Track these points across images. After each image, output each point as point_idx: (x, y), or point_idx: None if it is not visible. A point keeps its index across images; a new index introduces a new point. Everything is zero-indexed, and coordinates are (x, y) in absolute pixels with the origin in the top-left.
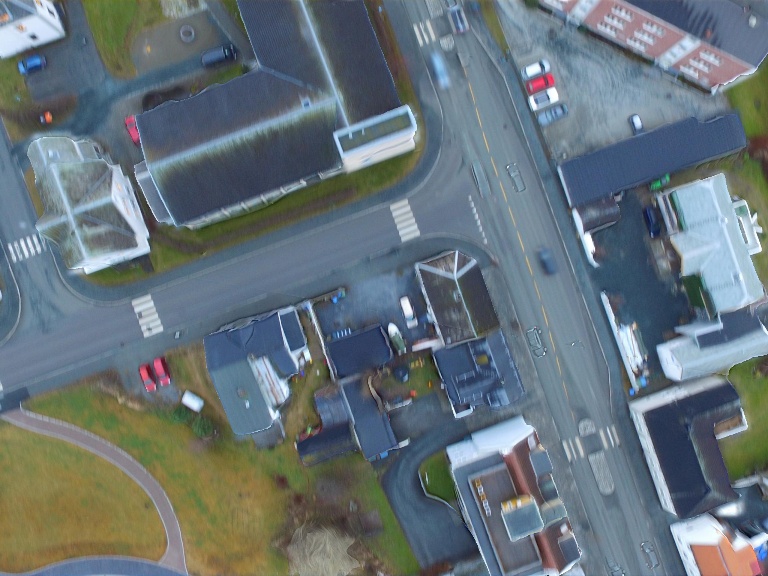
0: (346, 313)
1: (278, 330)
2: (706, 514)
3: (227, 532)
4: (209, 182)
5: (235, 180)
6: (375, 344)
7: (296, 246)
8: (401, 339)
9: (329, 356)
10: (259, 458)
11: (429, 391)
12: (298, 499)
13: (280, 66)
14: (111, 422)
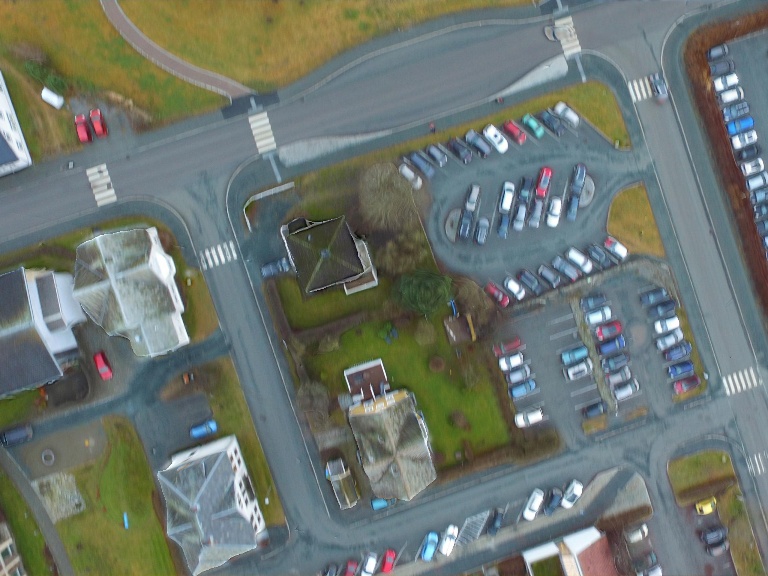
0: None
1: None
2: None
3: None
4: None
5: None
6: None
7: None
8: None
9: None
10: None
11: None
12: None
13: None
14: (148, 82)
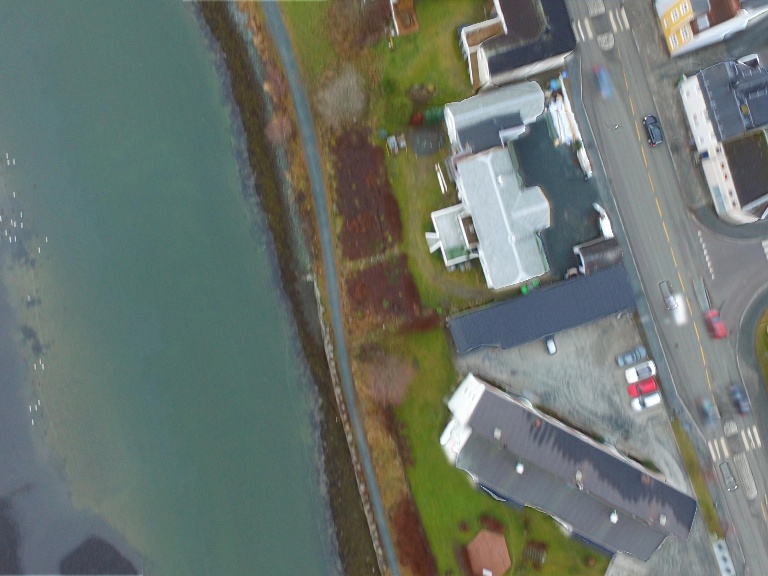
0: None
1: None
2: None
3: None
4: None
5: None
6: None
7: None
8: None
9: None
10: None
11: None
12: None
13: None
14: None
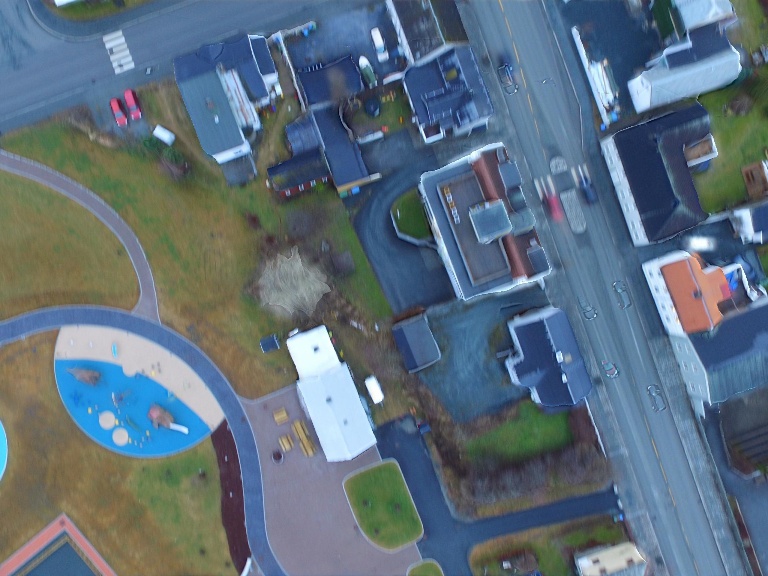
0: (317, 49)
1: (247, 46)
2: (677, 250)
3: (200, 279)
4: None
5: None
6: (345, 72)
7: None
8: (372, 72)
9: (300, 87)
10: (231, 196)
11: (400, 127)
12: (270, 239)
13: None
14: (83, 163)
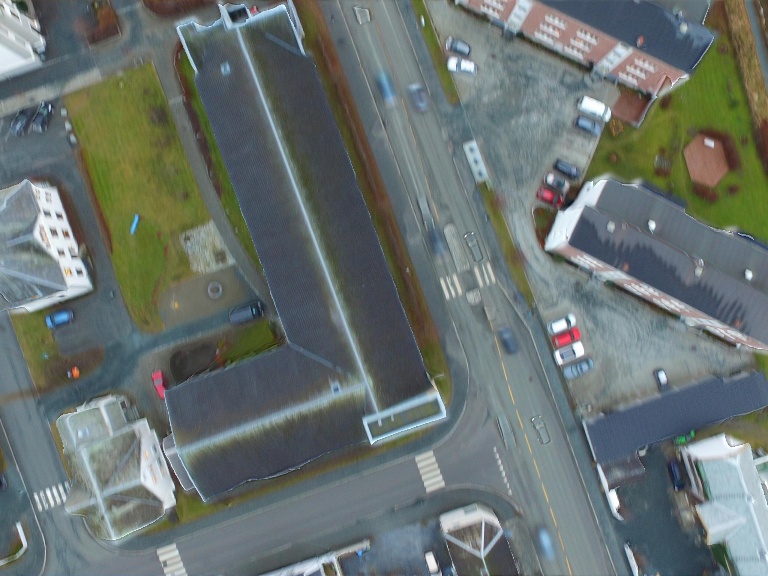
0: (370, 564)
1: None
2: None
3: None
4: (238, 461)
5: (264, 459)
6: None
7: (321, 497)
8: None
9: None
10: None
11: None
12: None
13: (309, 346)
14: None
